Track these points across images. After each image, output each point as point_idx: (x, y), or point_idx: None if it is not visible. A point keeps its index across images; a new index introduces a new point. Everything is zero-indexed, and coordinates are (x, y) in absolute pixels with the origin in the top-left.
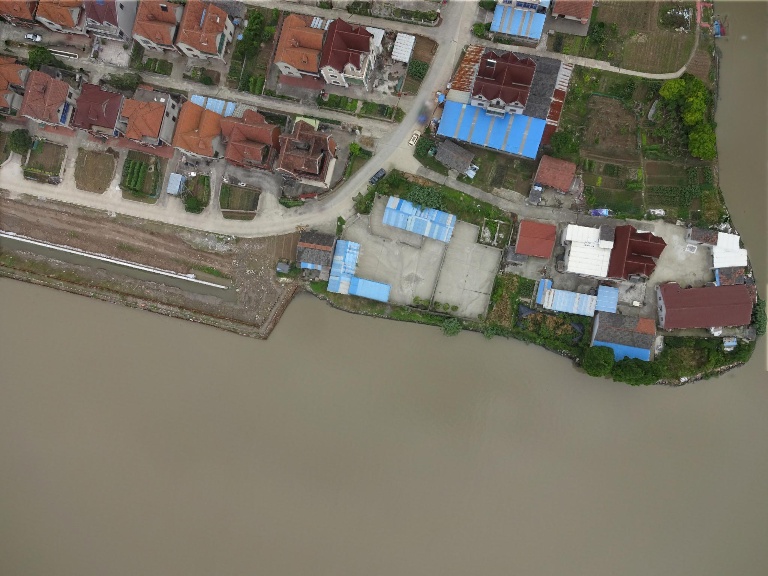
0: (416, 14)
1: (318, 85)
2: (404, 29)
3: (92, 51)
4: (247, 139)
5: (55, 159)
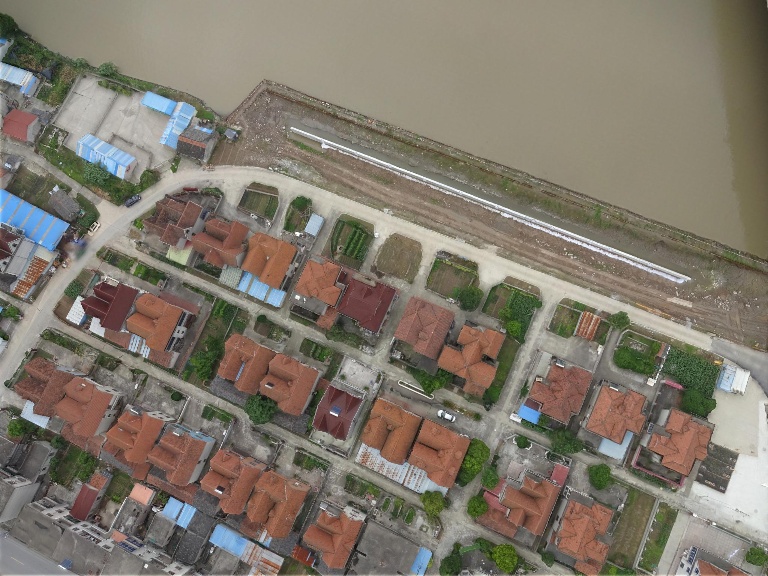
0: (60, 340)
1: (165, 297)
2: (78, 333)
3: (380, 383)
4: (222, 241)
5: (441, 278)
